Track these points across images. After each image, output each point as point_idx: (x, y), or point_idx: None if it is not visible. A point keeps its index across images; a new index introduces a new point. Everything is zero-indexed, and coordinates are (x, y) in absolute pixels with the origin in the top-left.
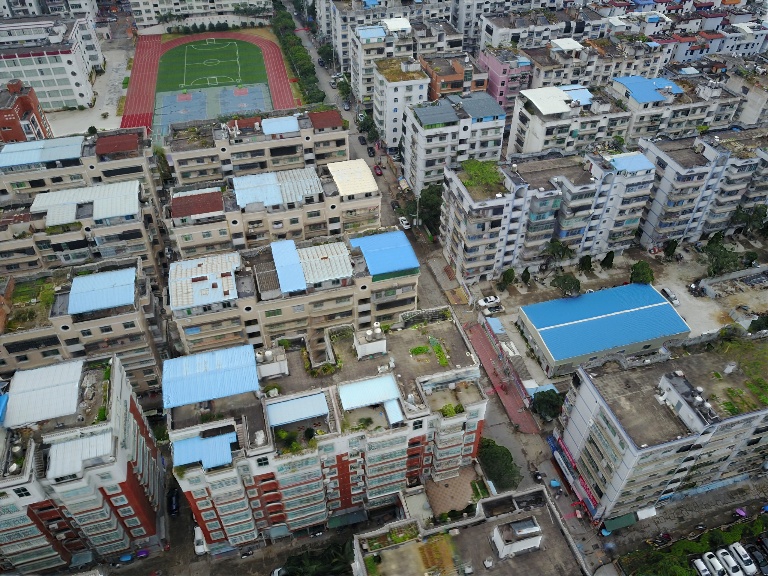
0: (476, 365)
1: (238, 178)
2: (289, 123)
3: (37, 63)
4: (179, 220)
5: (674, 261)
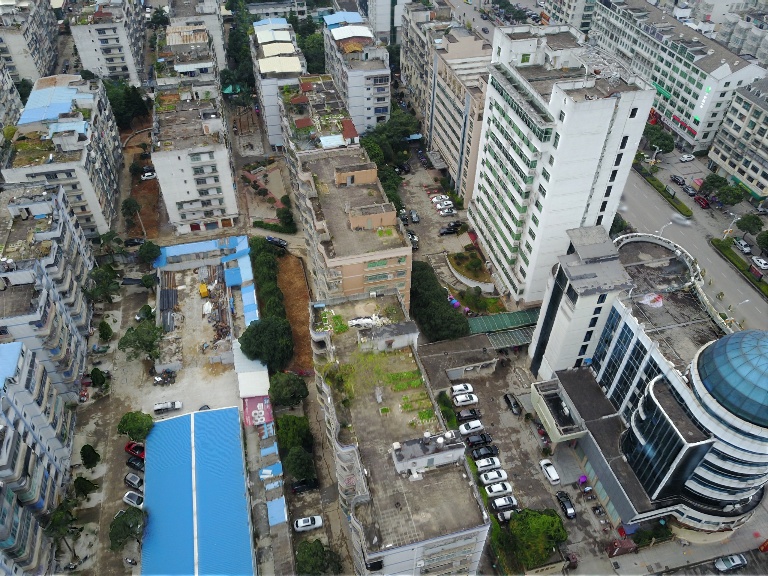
0: None
1: None
2: None
3: None
4: None
5: (108, 382)
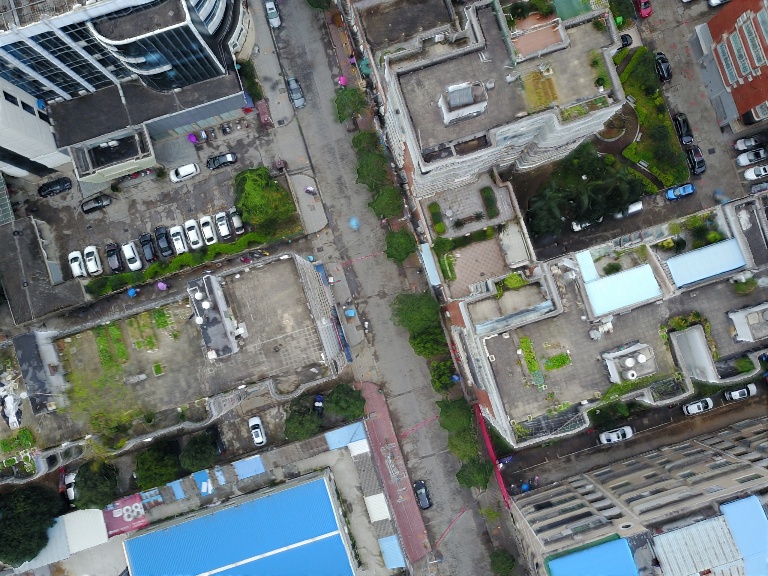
0: (484, 336)
1: None
2: None
3: None
4: None
5: None
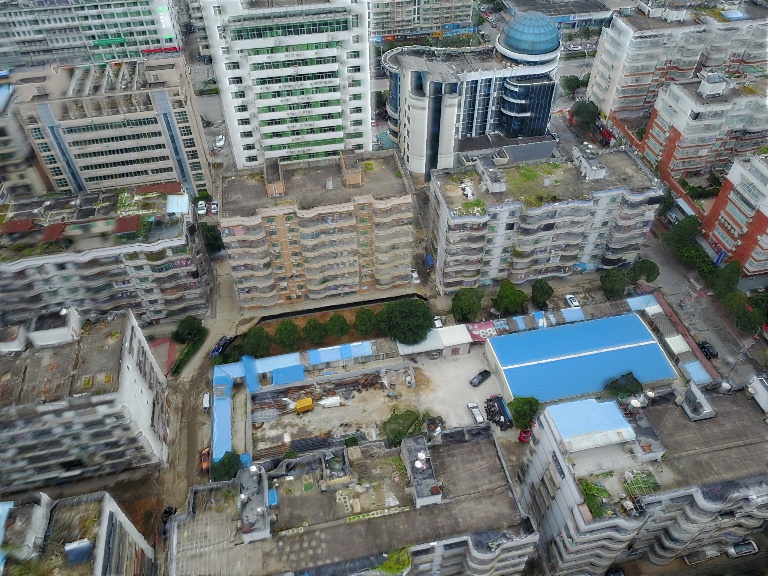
0: (757, 156)
1: None
2: None
3: None
4: None
5: None
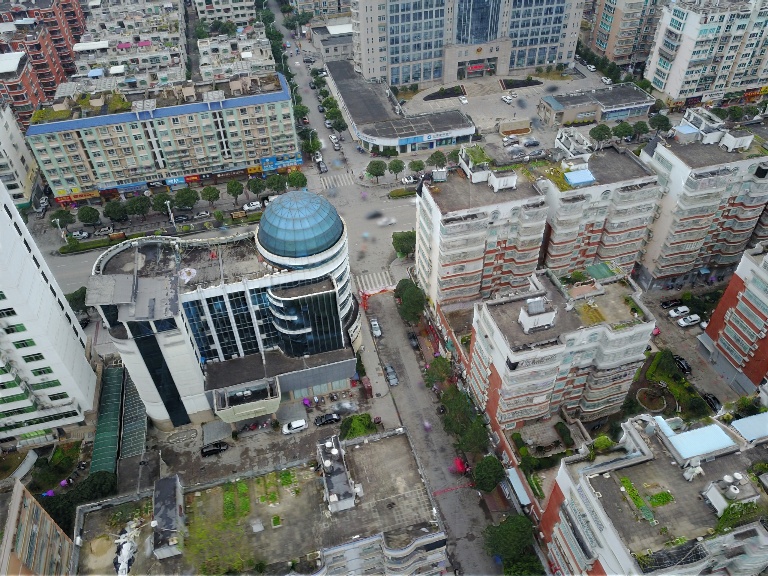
0: (587, 474)
1: None
2: None
3: None
4: None
5: None
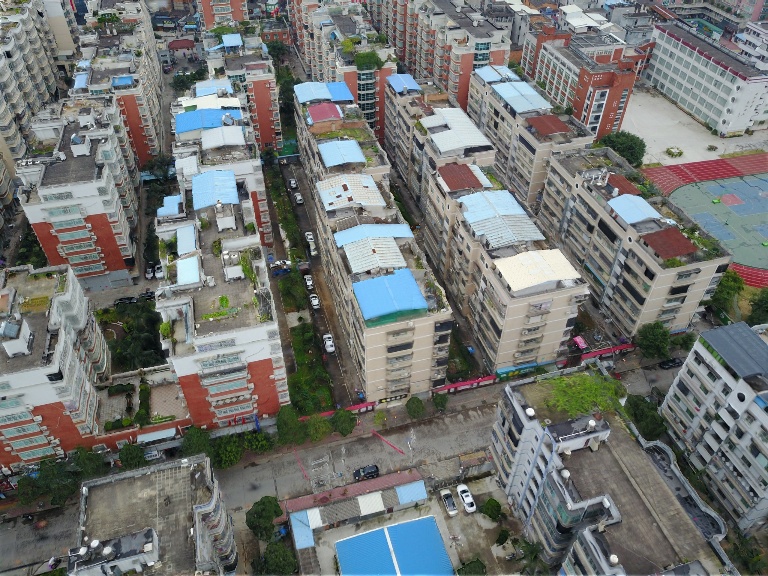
0: None
1: (506, 192)
2: (637, 213)
3: (719, 74)
4: (438, 174)
5: None
